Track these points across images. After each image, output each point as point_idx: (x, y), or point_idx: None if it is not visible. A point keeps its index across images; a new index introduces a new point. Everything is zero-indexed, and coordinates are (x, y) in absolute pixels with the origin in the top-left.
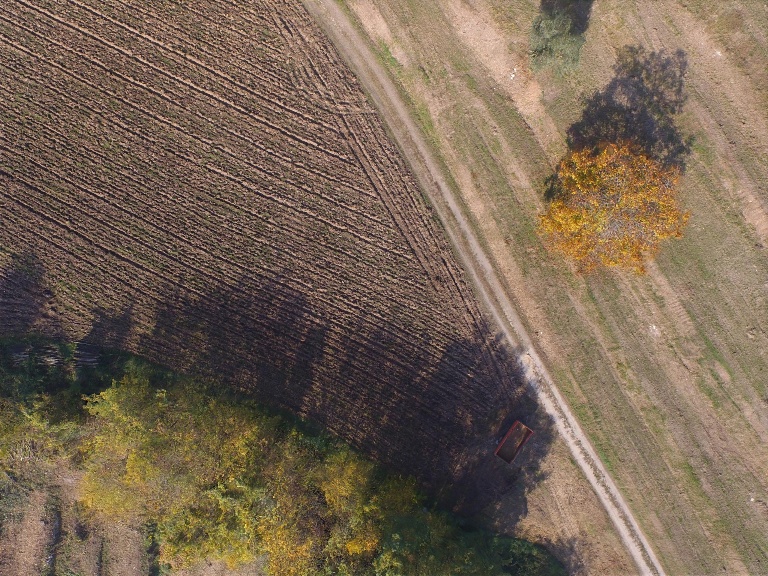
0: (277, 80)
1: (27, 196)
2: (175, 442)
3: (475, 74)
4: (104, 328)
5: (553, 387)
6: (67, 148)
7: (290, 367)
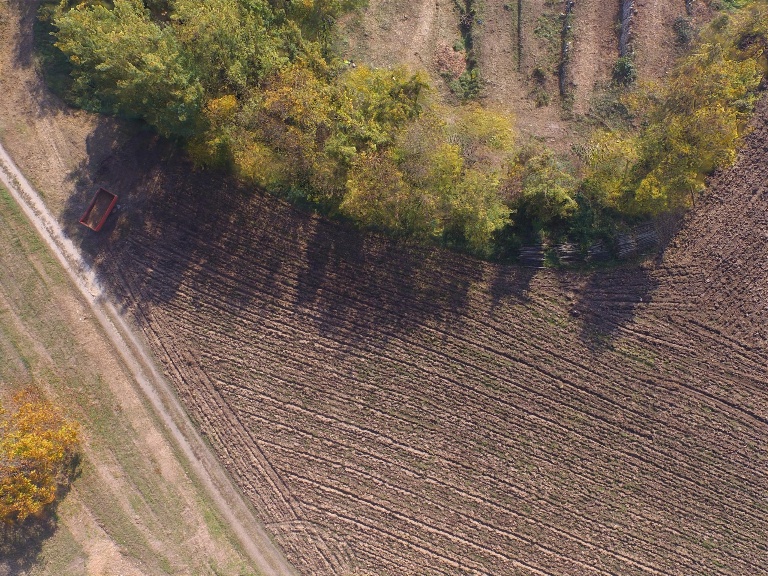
0: (366, 549)
1: (604, 409)
2: (419, 186)
3: (162, 575)
4: (518, 284)
5: (67, 266)
6: (569, 461)
7: (331, 262)
